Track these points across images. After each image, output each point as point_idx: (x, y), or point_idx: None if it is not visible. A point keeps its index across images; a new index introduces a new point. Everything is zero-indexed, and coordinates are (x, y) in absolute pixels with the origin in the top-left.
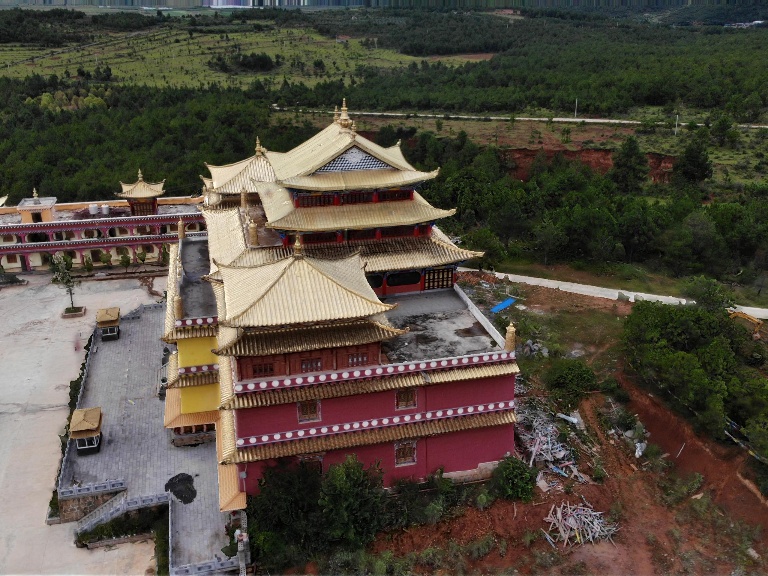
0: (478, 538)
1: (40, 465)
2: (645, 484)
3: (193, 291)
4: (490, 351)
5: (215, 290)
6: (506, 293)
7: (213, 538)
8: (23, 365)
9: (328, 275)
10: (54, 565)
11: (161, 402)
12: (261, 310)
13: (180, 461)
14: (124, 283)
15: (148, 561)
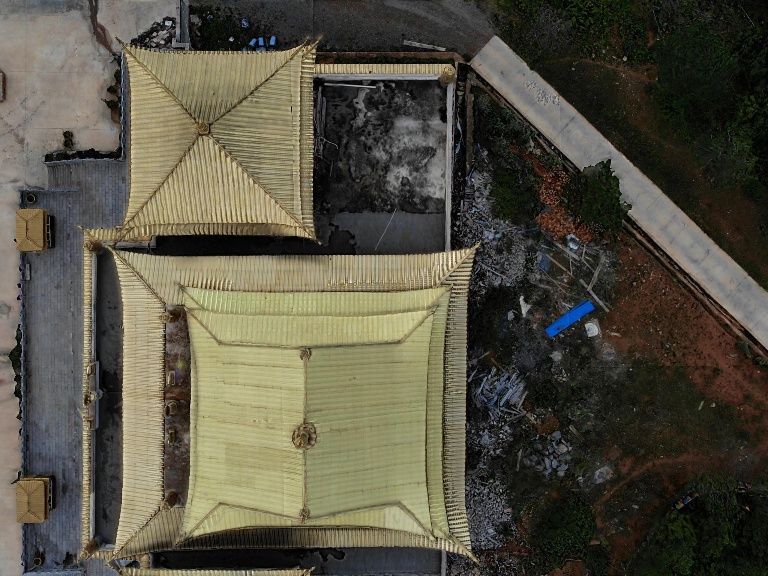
0: None
1: (5, 467)
2: None
3: (113, 444)
4: None
5: None
6: (589, 286)
7: None
8: None
9: None
10: None
11: None
12: None
13: None
14: None
15: None
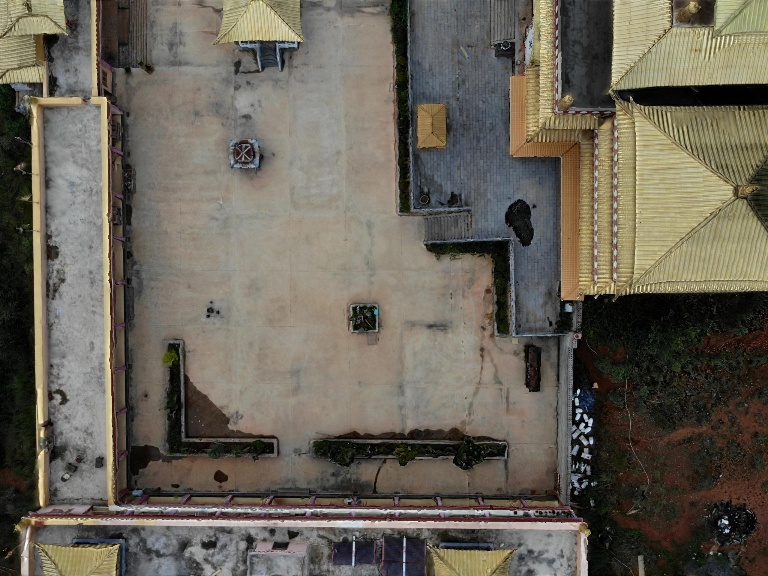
0: (763, 348)
1: (376, 119)
2: None
3: (575, 7)
4: None
5: (619, 120)
6: None
7: (547, 297)
8: None
9: (764, 215)
10: (412, 268)
11: (497, 61)
12: (675, 261)
13: (519, 180)
14: None
15: (486, 280)
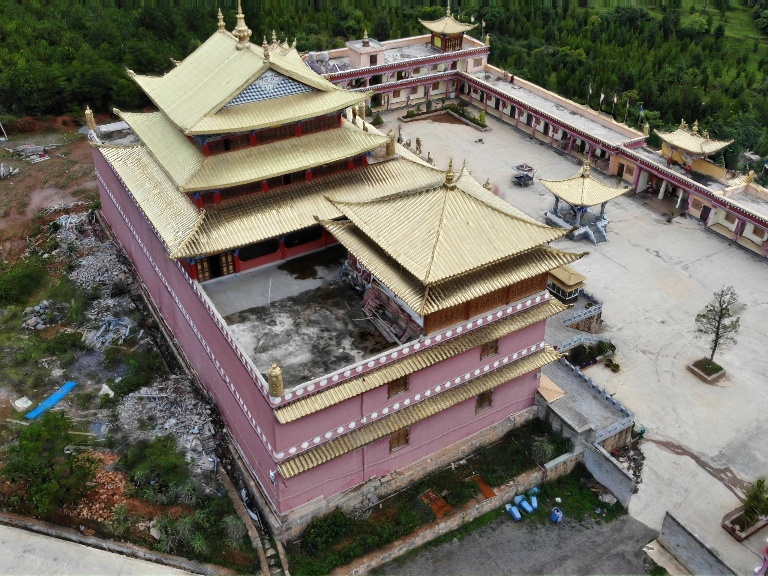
0: None
1: None
2: (1, 237)
3: None
4: (107, 139)
5: None
6: None
7: None
8: (623, 285)
9: None
10: None
11: None
12: None
13: None
14: (762, 466)
15: None
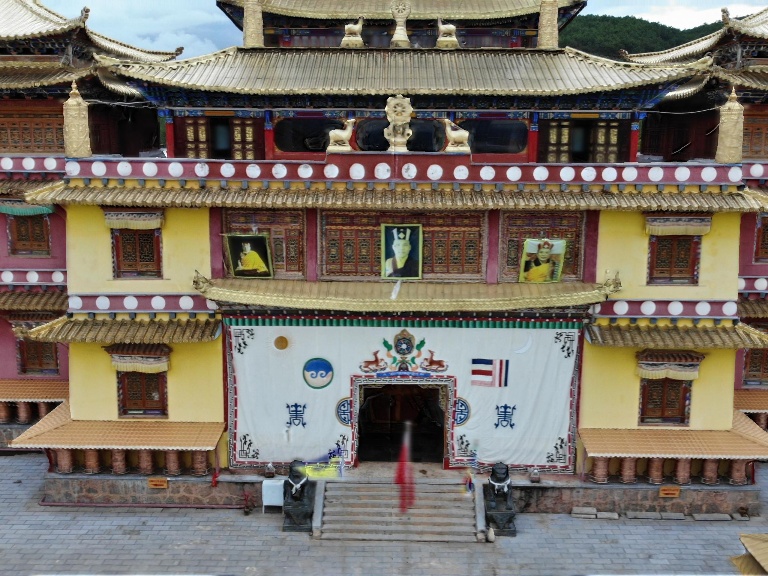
0: None
1: None
2: None
3: None
4: None
5: None
6: None
7: None
8: None
9: None
10: None
11: (528, 534)
12: None
13: None
14: None
15: None
